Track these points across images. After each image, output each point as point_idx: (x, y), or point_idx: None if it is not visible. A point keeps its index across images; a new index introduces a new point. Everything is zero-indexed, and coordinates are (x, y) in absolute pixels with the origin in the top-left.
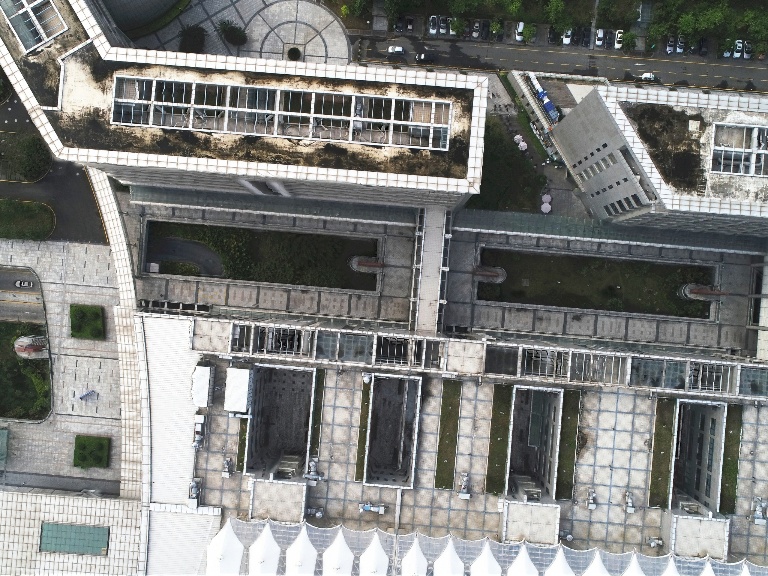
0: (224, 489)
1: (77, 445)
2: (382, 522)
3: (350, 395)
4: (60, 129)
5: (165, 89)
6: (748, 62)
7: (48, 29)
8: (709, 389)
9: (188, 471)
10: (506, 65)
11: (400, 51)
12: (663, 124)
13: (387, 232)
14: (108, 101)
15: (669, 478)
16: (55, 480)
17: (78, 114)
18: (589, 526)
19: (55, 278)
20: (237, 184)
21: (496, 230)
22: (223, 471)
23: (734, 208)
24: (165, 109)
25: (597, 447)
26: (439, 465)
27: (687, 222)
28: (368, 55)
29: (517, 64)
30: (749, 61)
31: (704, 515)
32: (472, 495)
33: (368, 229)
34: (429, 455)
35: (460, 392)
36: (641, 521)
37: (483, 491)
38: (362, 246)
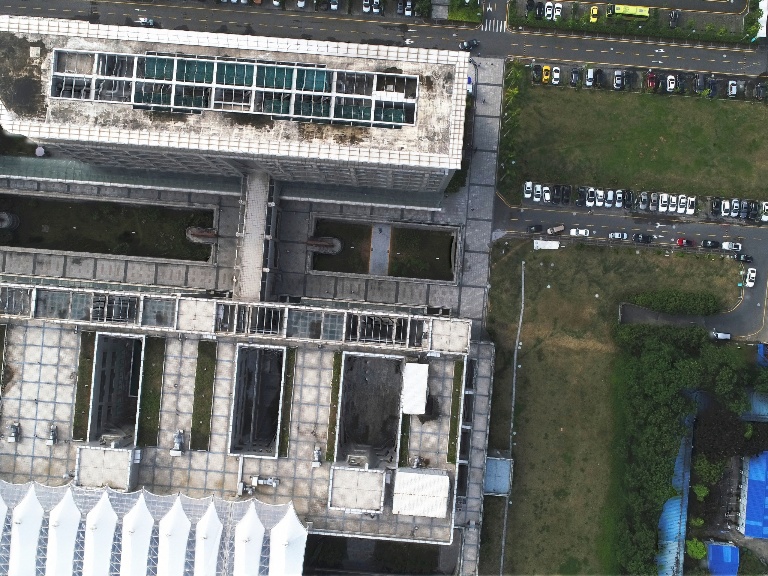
0: None
1: None
2: None
3: None
4: None
5: None
6: (247, 7)
7: None
8: (114, 320)
9: None
10: (9, 12)
11: None
12: (5, 51)
13: None
14: None
15: (89, 411)
16: None
17: None
18: (15, 460)
19: None
20: None
21: None
22: None
23: (73, 133)
24: None
25: (23, 381)
26: None
27: (115, 157)
28: None
29: (20, 10)
30: (248, 6)
31: (107, 445)
32: None
33: None
34: None
35: None
36: (66, 454)
37: None
38: None
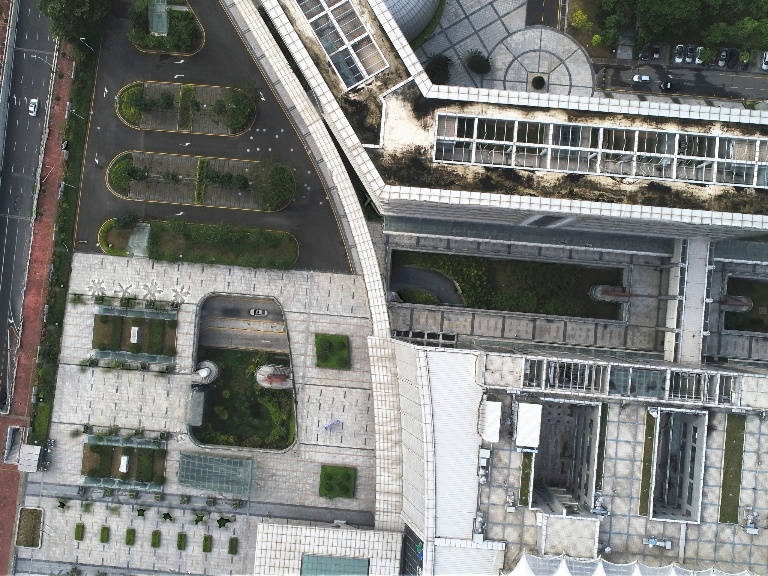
0: (506, 523)
1: (324, 475)
2: (666, 557)
3: (633, 429)
4: (381, 167)
5: (487, 127)
6: None
7: (367, 66)
8: None
9: (472, 506)
10: (751, 94)
11: (647, 80)
12: None
13: (633, 261)
14: (430, 139)
15: None
16: (300, 510)
17: (400, 152)
18: None
19: (299, 307)
20: (514, 217)
21: (752, 260)
22: (508, 506)
23: None
24: (481, 146)
25: None
26: (724, 499)
27: None
28: (612, 84)
29: (763, 93)
30: None
31: None
32: None
33: (614, 258)
34: (713, 489)
35: (744, 426)
36: None
37: (767, 525)
38: (602, 275)
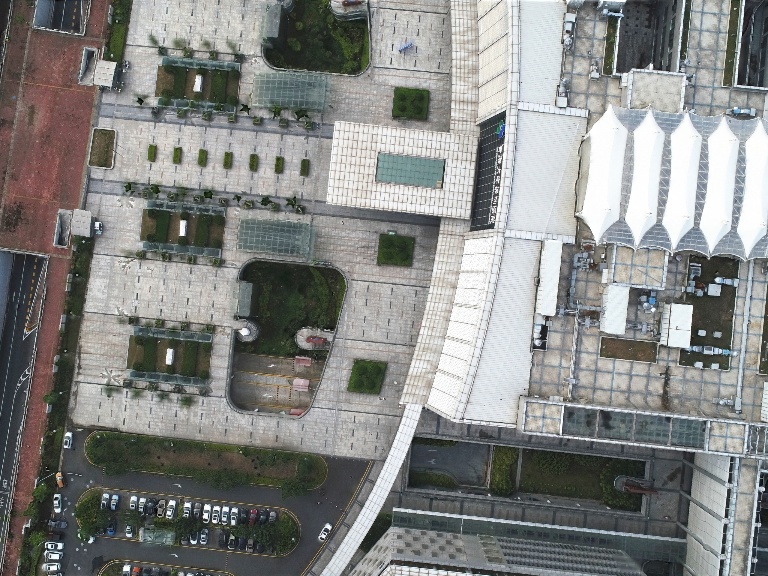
0: (589, 93)
1: (397, 95)
2: None
3: (718, 1)
4: None
5: None
6: None
7: None
8: None
9: (555, 73)
10: None
11: None
12: None
13: None
14: None
15: None
16: None
17: None
18: None
19: None
20: None
21: None
22: (593, 71)
23: None
24: None
25: None
26: None
27: None
28: None
29: None
30: None
31: None
32: None
33: None
34: None
35: None
36: None
37: None
38: None
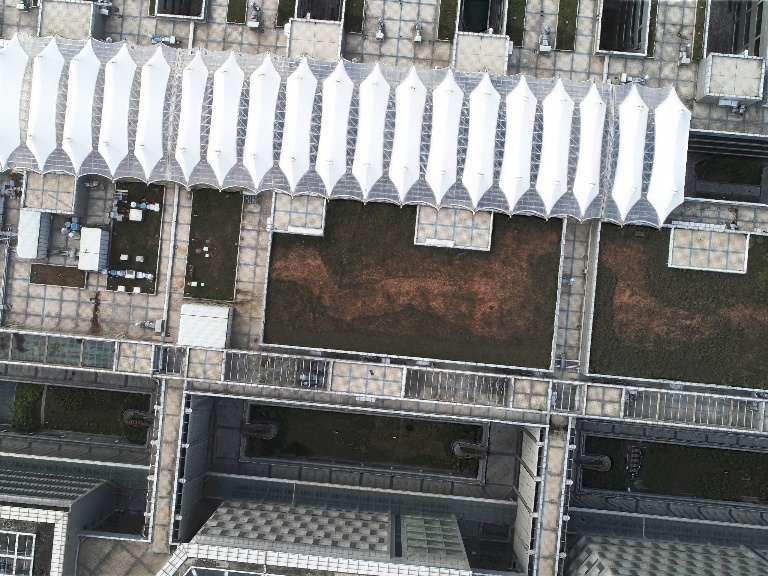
0: (21, 25)
1: None
2: None
3: None
4: None
5: None
6: None
7: None
8: None
9: None
10: None
11: None
12: None
13: None
14: None
15: (457, 9)
16: None
17: None
18: None
19: None
20: None
21: None
22: (18, 3)
23: None
24: None
25: None
26: None
27: None
28: None
29: None
30: None
31: (485, 31)
32: (264, 30)
33: None
34: None
35: None
36: (430, 55)
37: (275, 26)
38: None
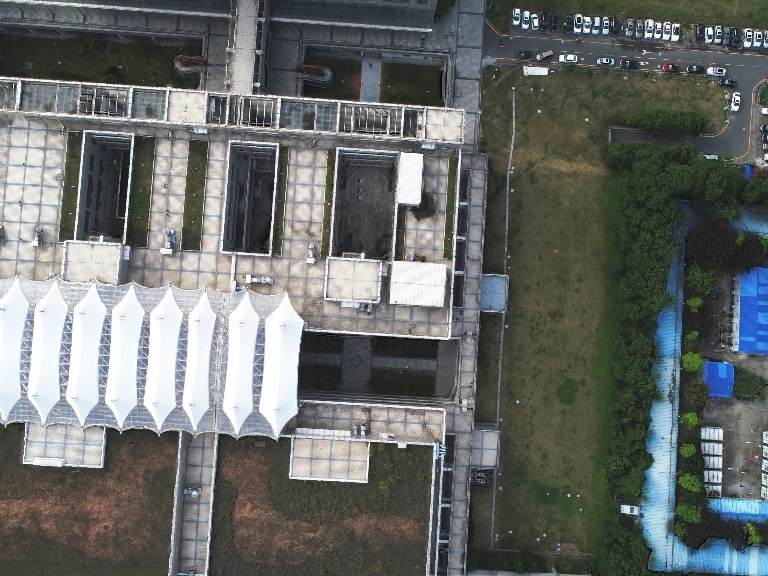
0: None
1: None
2: None
3: None
4: None
5: None
6: None
7: None
8: (103, 113)
9: None
10: None
11: None
12: None
13: None
14: None
15: None
16: None
17: None
18: None
19: None
20: None
21: None
22: None
23: None
24: None
25: (7, 183)
26: None
27: None
28: None
29: None
30: None
31: (95, 239)
32: None
33: None
34: None
35: None
36: (52, 257)
37: None
38: None
